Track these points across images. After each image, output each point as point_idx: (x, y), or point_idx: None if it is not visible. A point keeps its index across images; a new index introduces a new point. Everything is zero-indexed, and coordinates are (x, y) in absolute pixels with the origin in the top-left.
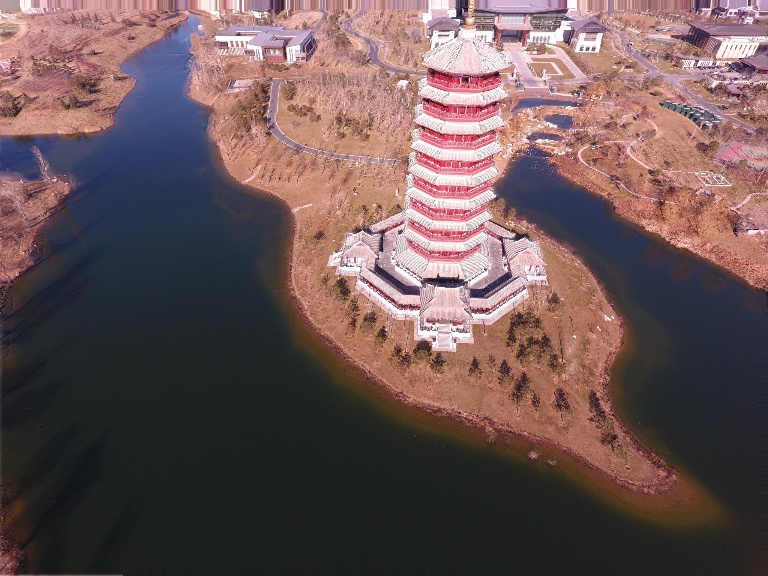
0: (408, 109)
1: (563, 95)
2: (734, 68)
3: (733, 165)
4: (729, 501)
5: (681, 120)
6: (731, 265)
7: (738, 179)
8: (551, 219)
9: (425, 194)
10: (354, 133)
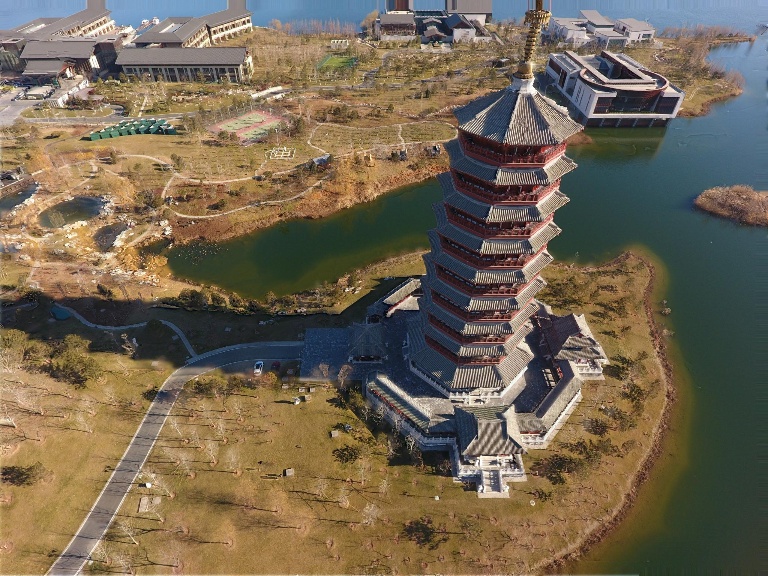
0: None
1: None
2: (20, 84)
3: (257, 139)
4: (630, 239)
5: (140, 139)
6: (399, 182)
7: (283, 143)
8: (325, 263)
9: None
10: (1, 498)
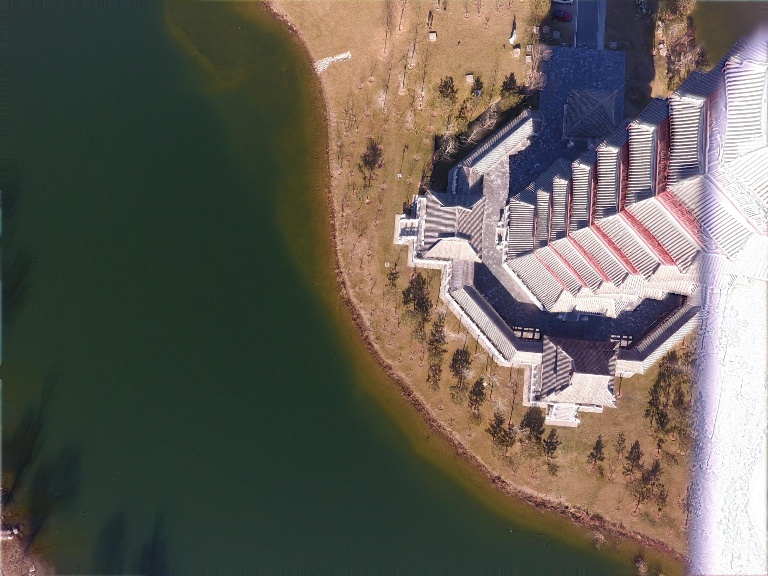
0: None
1: None
2: None
3: None
4: None
5: None
6: None
7: None
8: None
9: (610, 253)
10: None
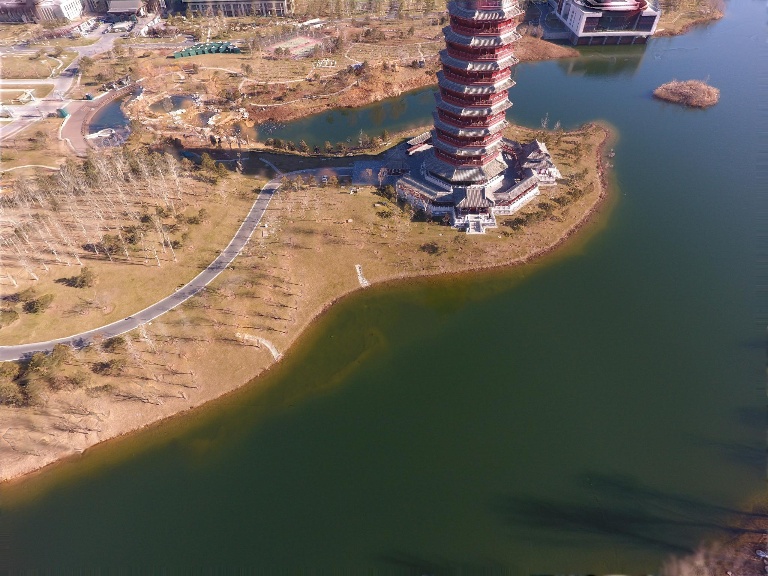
0: (137, 173)
1: (102, 96)
2: (105, 21)
3: (305, 54)
4: None
5: (213, 56)
6: (419, 84)
7: (326, 57)
8: (363, 133)
9: None
10: (186, 224)
